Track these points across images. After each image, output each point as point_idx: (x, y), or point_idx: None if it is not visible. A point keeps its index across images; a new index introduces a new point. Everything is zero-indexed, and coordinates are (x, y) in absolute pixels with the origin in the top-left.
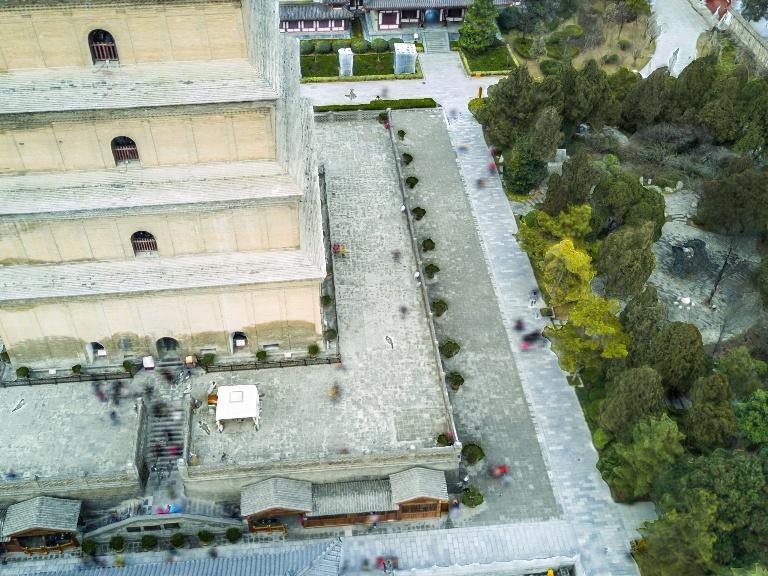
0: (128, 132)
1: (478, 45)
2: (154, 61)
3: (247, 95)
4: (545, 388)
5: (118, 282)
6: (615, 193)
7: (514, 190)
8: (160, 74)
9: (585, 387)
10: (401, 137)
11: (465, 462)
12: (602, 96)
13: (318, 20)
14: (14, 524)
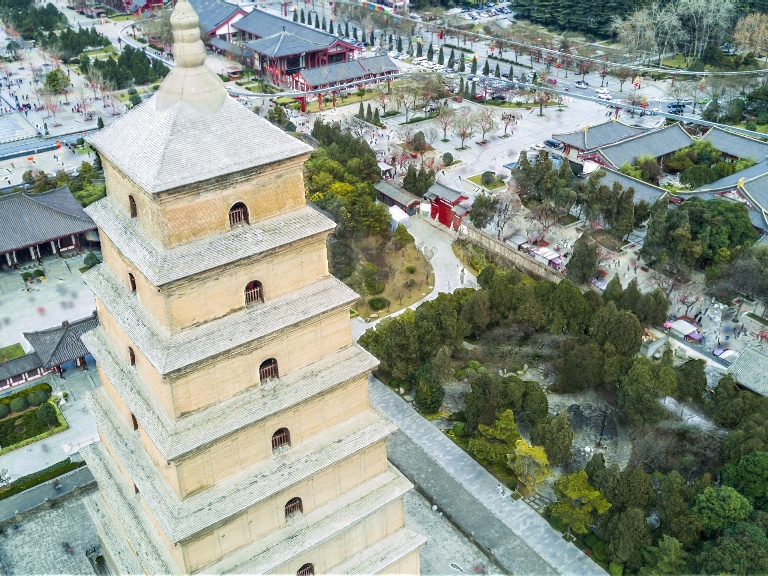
0: (297, 493)
1: None
2: (312, 435)
3: (380, 434)
4: (556, 552)
5: None
6: (513, 392)
7: (430, 412)
8: (319, 443)
9: (578, 539)
10: None
11: None
12: None
13: None
14: None
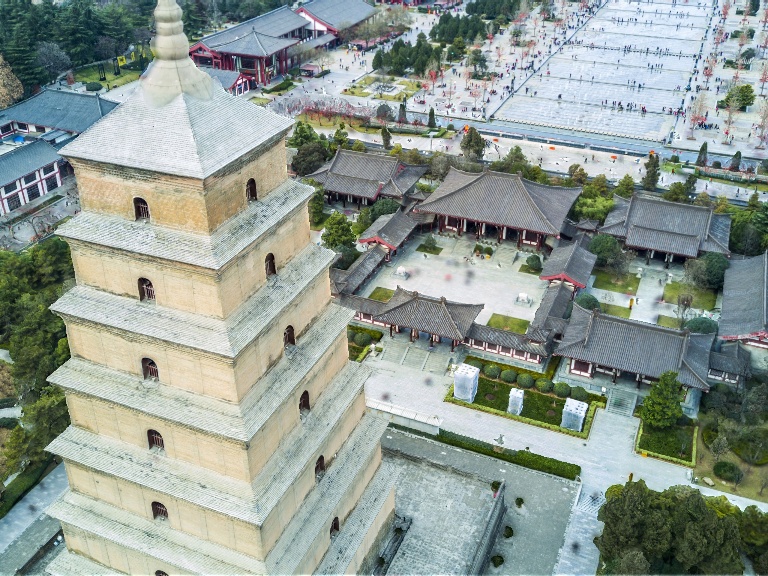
0: (163, 501)
1: (656, 422)
2: (188, 461)
3: (239, 513)
4: None
5: None
6: None
7: None
8: (189, 472)
9: None
10: (517, 505)
11: None
12: (719, 549)
13: (515, 349)
14: None
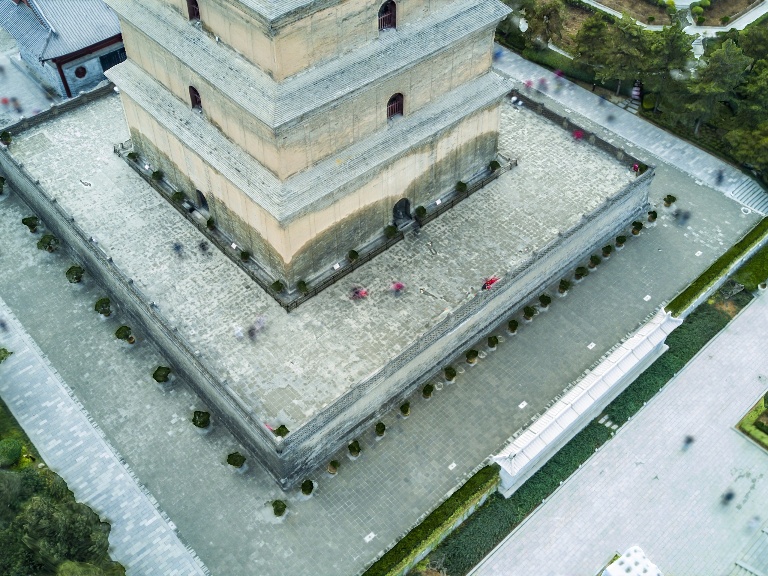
0: None
1: None
2: None
3: None
4: None
5: None
6: None
7: None
8: None
9: None
10: None
11: (5, 188)
12: None
13: None
14: None
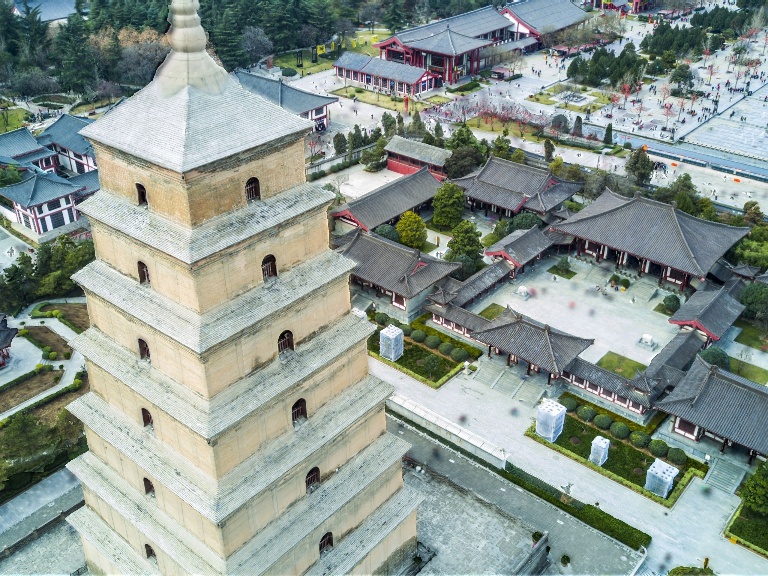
0: (151, 479)
1: (757, 507)
2: (171, 446)
3: (200, 507)
4: None
5: (130, 569)
6: None
7: None
8: (170, 456)
9: None
10: (562, 563)
11: None
12: None
13: None
14: None
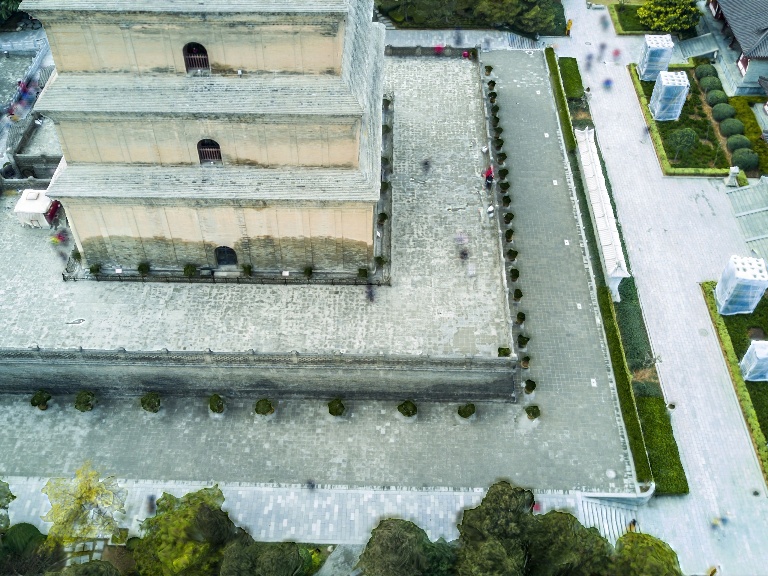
0: None
1: None
2: None
3: None
4: None
5: None
6: None
7: None
8: None
9: None
10: None
11: None
12: None
13: None
14: (23, 121)
